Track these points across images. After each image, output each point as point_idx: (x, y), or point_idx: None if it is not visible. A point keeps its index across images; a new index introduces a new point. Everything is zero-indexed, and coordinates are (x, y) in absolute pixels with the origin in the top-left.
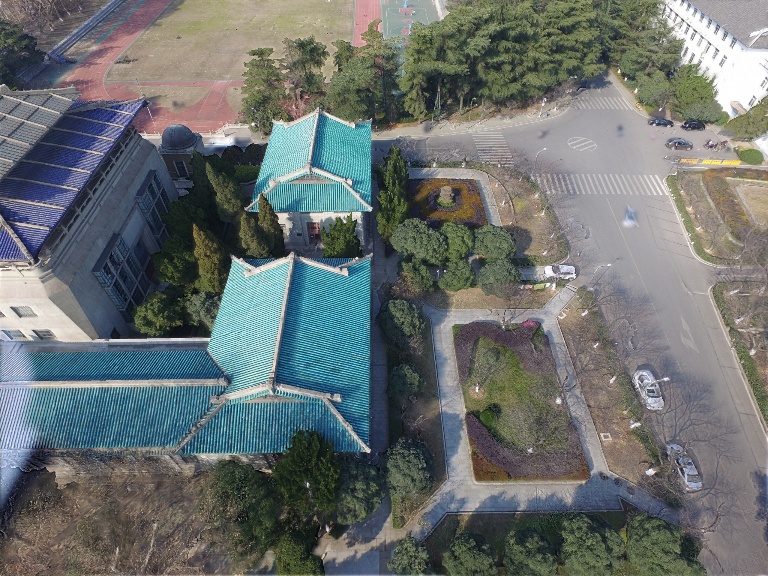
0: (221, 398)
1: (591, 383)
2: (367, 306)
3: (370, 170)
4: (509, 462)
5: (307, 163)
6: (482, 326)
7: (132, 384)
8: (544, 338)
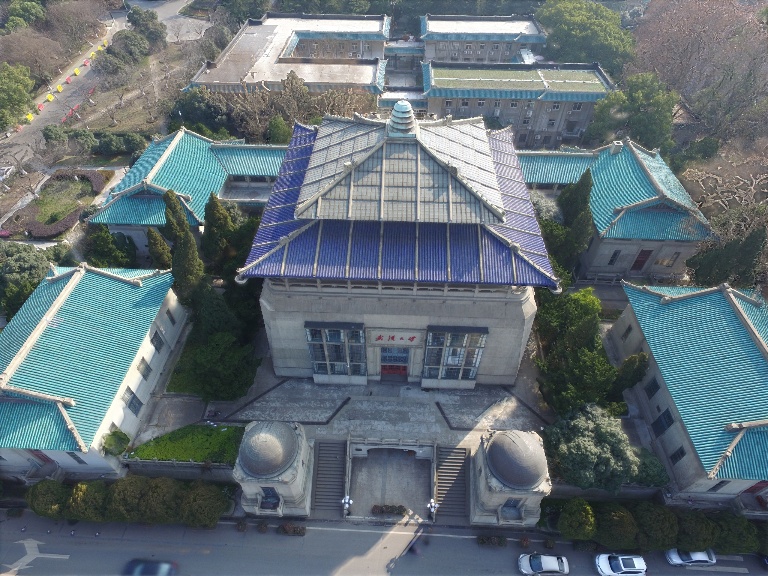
0: (215, 141)
1: (5, 208)
2: (114, 190)
3: (8, 324)
4: (92, 173)
5: (83, 264)
6: (41, 231)
7: (261, 147)
8: (5, 223)
